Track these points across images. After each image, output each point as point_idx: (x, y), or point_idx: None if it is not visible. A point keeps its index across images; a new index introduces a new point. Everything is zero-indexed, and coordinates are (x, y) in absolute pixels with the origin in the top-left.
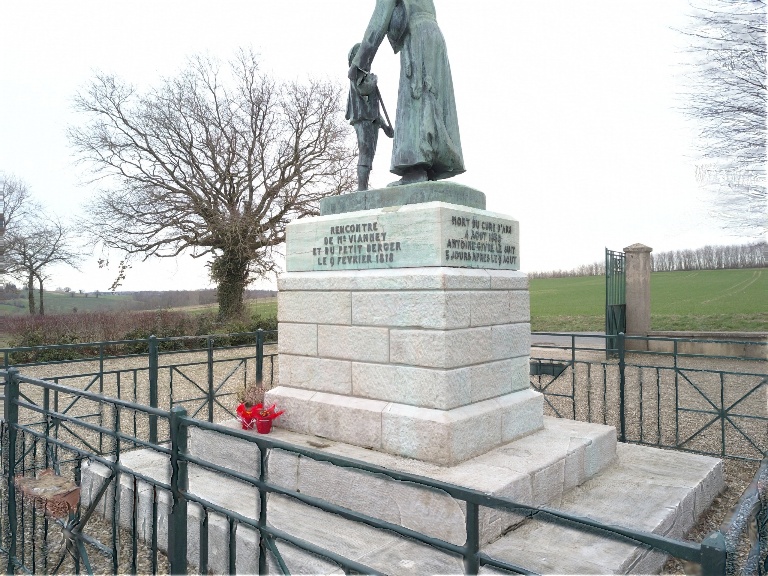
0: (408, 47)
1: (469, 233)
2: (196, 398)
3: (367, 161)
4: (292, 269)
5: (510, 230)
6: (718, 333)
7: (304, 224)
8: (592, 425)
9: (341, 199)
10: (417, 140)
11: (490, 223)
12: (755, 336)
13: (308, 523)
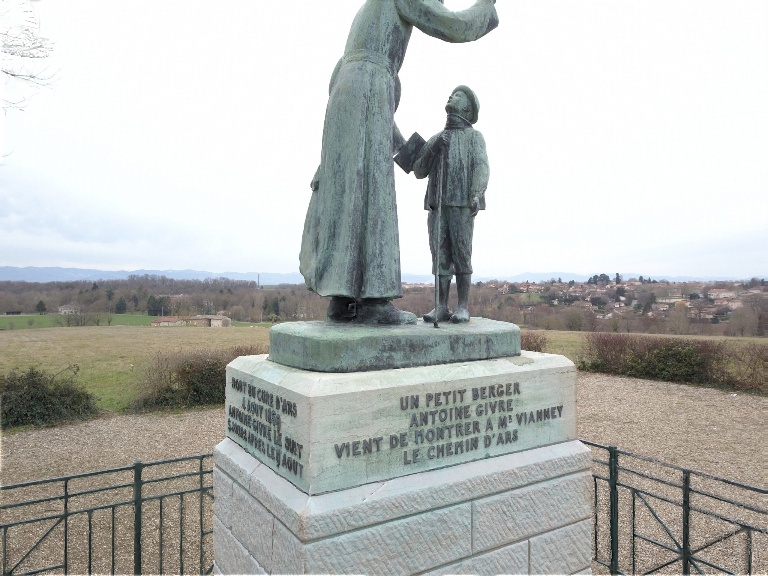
0: None
1: (247, 402)
2: (664, 545)
3: None
4: None
5: (296, 410)
6: None
7: None
8: None
9: None
10: None
11: (267, 392)
12: None
13: None
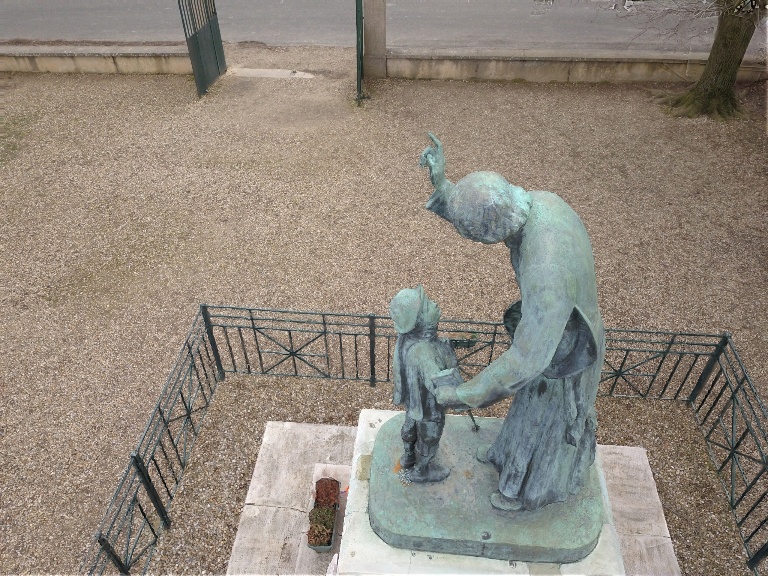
0: (575, 385)
1: None
2: None
3: (436, 449)
4: None
5: None
6: (455, 56)
7: (379, 575)
8: None
9: (434, 540)
10: (563, 481)
11: None
12: (487, 58)
13: None
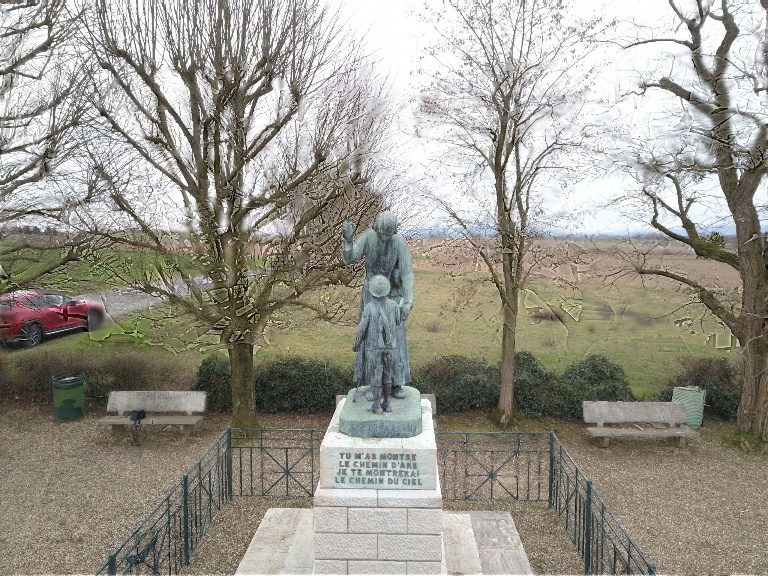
0: None
1: None
2: None
3: None
4: (436, 484)
5: None
6: None
7: None
8: (308, 516)
9: None
10: None
11: None
12: None
13: (502, 574)
